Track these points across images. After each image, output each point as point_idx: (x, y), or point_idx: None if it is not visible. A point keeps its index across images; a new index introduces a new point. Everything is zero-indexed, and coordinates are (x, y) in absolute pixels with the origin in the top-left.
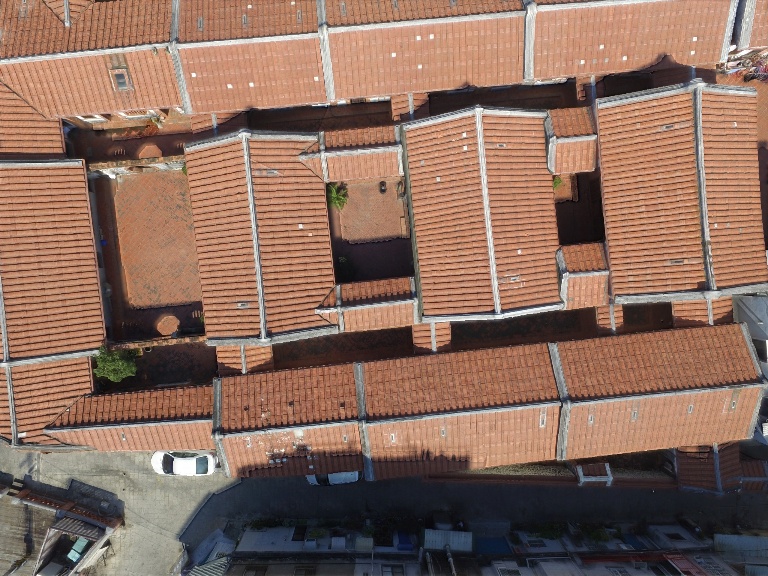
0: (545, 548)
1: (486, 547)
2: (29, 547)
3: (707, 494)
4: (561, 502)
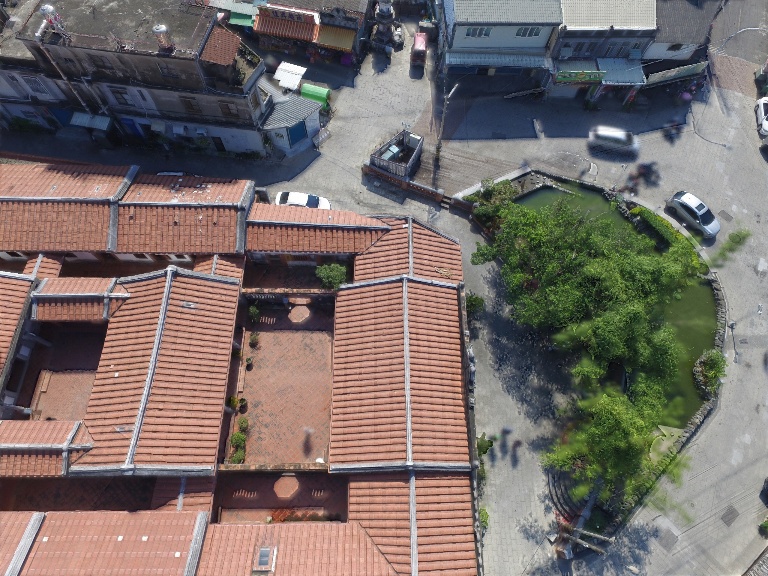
0: (20, 109)
1: None
2: (437, 162)
3: None
4: (8, 144)
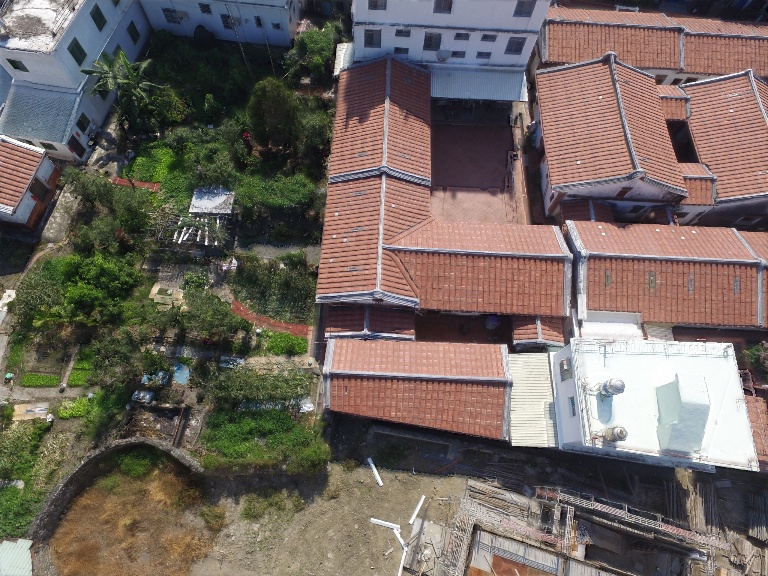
0: None
1: None
2: None
3: None
4: None
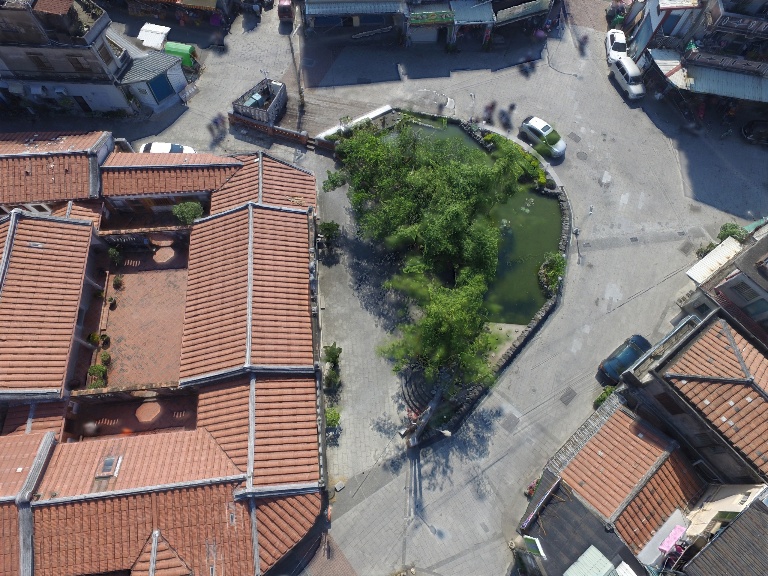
0: None
1: None
2: (302, 108)
3: None
4: None
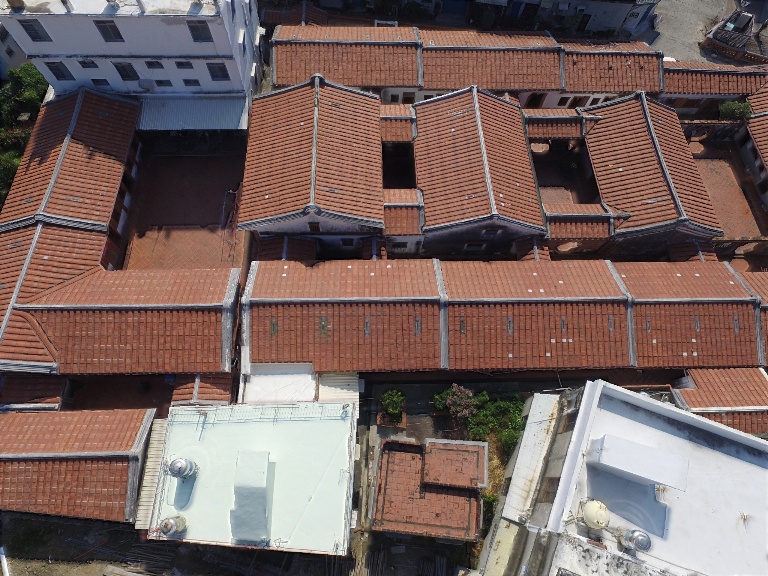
0: None
1: (458, 4)
2: (758, 39)
3: (311, 5)
4: None
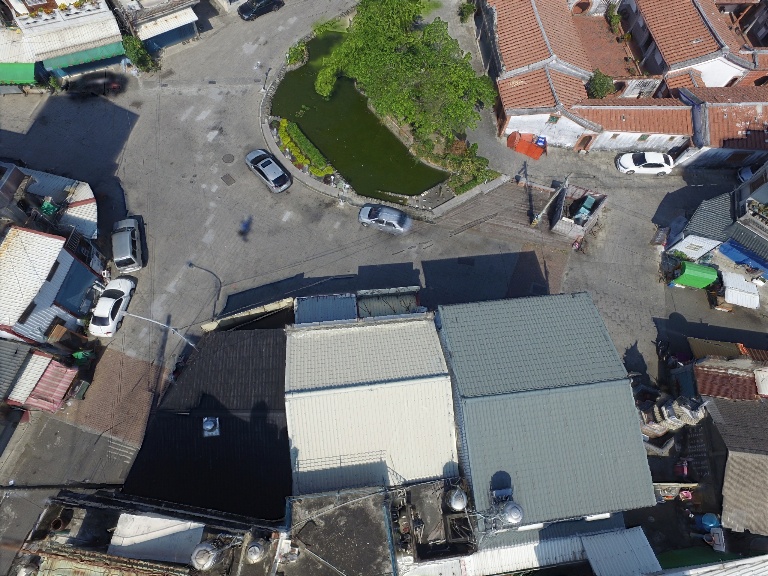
0: None
1: None
2: (532, 219)
3: None
4: None
